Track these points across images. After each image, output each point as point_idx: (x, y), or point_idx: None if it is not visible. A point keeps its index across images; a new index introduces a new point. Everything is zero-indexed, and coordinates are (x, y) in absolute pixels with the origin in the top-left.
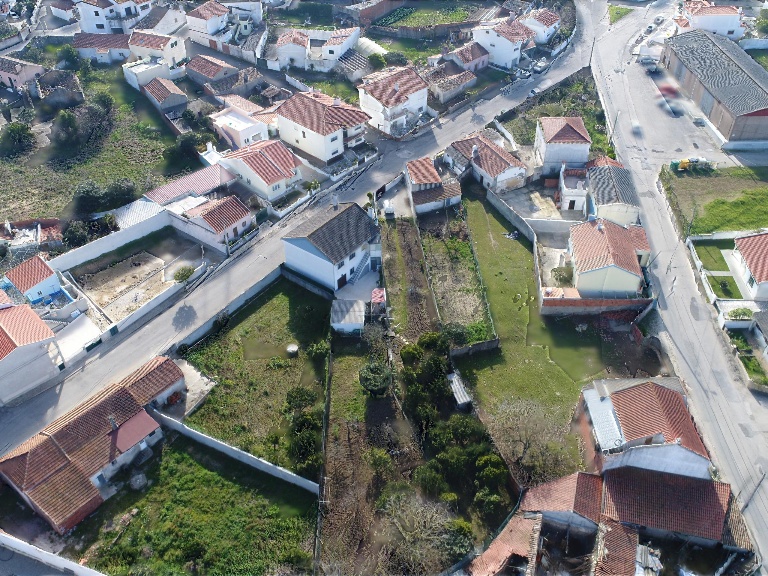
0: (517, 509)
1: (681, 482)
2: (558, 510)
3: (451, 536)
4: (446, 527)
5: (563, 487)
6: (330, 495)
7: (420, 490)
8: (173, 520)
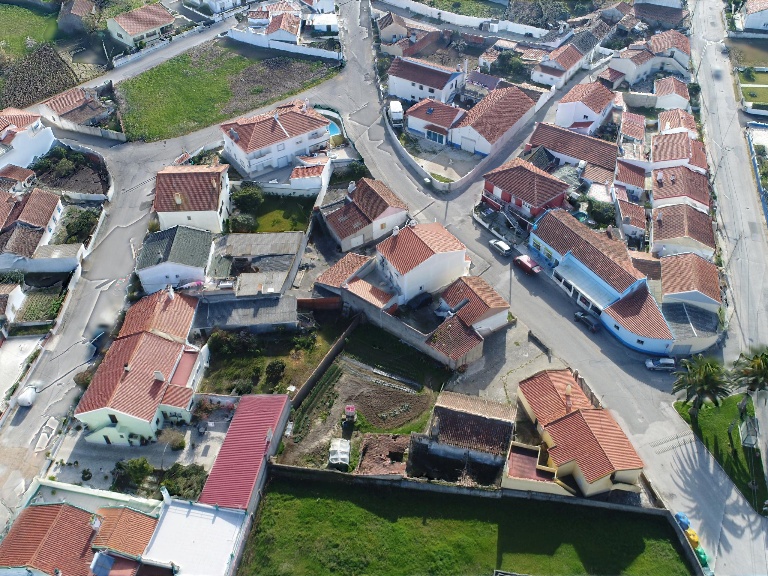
0: (592, 12)
1: (668, 9)
2: (609, 9)
3: (561, 8)
4: (560, 5)
5: (614, 5)
6: (513, 6)
7: (552, 1)
8: (448, 3)
